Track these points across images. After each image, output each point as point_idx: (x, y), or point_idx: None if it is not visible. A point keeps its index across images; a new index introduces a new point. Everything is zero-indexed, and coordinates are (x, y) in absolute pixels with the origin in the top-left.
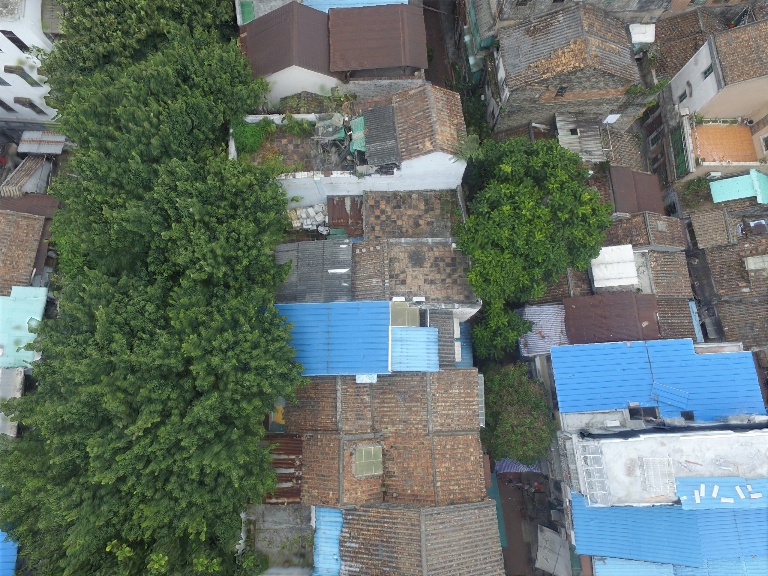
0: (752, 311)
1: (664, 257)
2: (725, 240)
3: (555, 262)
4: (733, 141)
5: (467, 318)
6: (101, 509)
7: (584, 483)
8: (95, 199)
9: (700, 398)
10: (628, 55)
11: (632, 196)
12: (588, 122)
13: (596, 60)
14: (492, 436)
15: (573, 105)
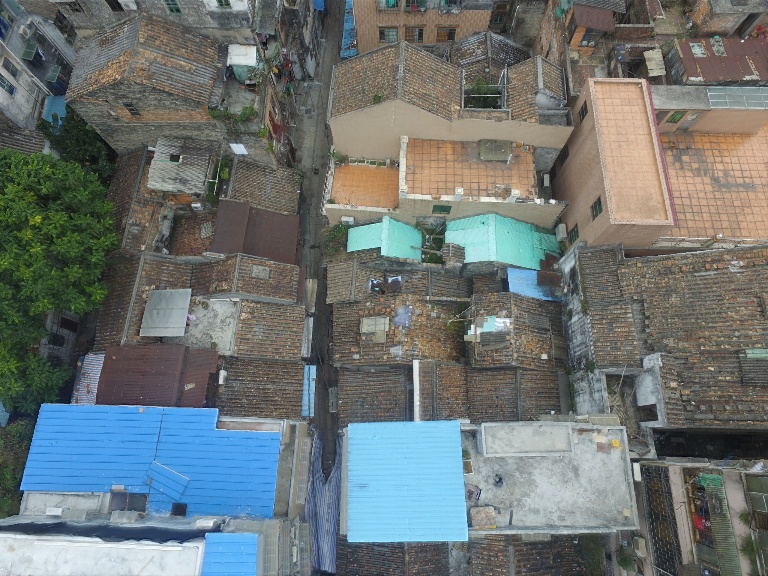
0: (367, 383)
1: (267, 309)
2: (348, 295)
3: None
4: (378, 184)
5: None
6: None
7: None
8: None
9: (201, 487)
10: (208, 75)
11: (239, 235)
12: (198, 149)
13: (142, 74)
14: None
15: (169, 128)
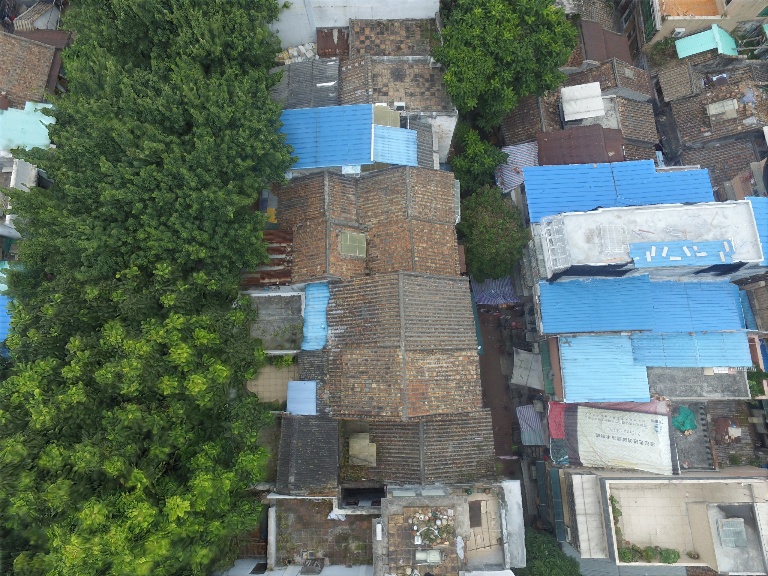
0: (714, 155)
1: (632, 105)
2: (689, 91)
3: (523, 65)
4: (697, 2)
5: (447, 149)
6: (111, 232)
7: None
8: None
9: None
10: None
11: (602, 48)
12: None
13: None
14: None
15: None
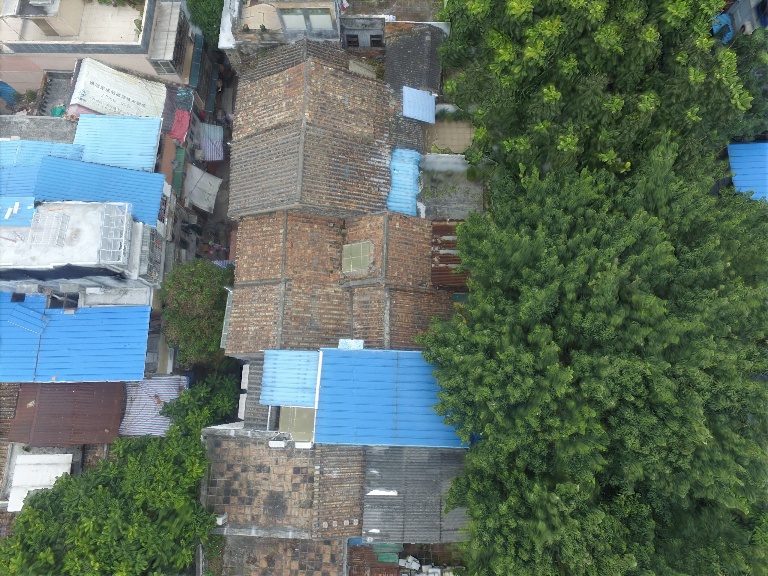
0: None
1: None
2: None
3: None
4: None
5: None
6: None
7: (137, 232)
8: None
9: None
10: None
11: None
12: None
13: None
14: (229, 285)
15: None
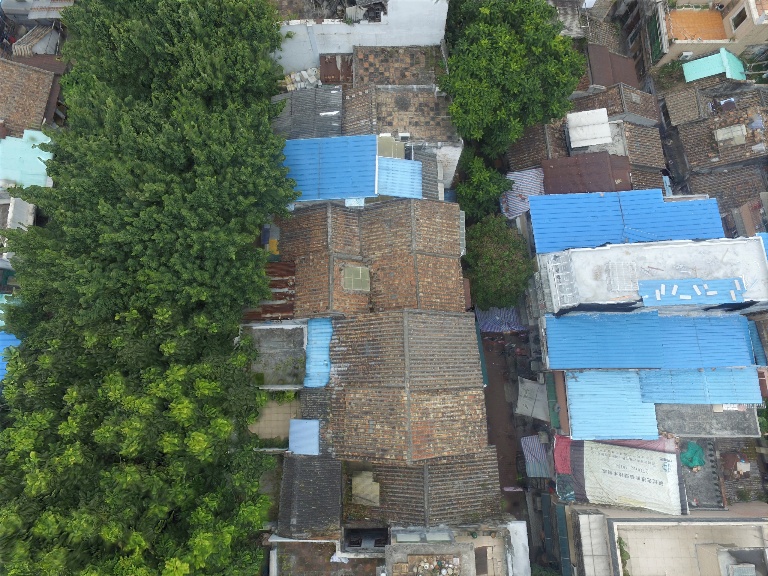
0: (721, 181)
1: (638, 130)
2: (696, 115)
3: (530, 96)
4: (705, 25)
5: (451, 176)
6: None
7: (557, 303)
8: (103, 23)
9: None
10: None
11: (608, 72)
12: (567, 1)
13: None
14: None
15: None
